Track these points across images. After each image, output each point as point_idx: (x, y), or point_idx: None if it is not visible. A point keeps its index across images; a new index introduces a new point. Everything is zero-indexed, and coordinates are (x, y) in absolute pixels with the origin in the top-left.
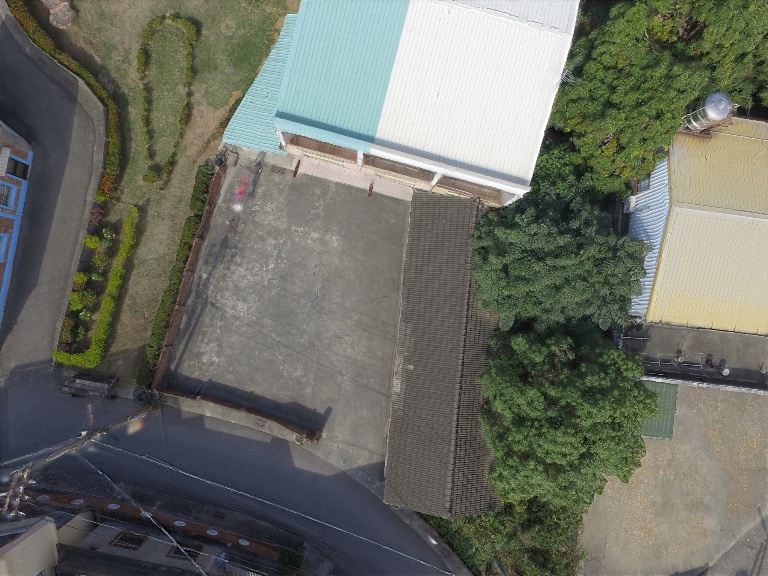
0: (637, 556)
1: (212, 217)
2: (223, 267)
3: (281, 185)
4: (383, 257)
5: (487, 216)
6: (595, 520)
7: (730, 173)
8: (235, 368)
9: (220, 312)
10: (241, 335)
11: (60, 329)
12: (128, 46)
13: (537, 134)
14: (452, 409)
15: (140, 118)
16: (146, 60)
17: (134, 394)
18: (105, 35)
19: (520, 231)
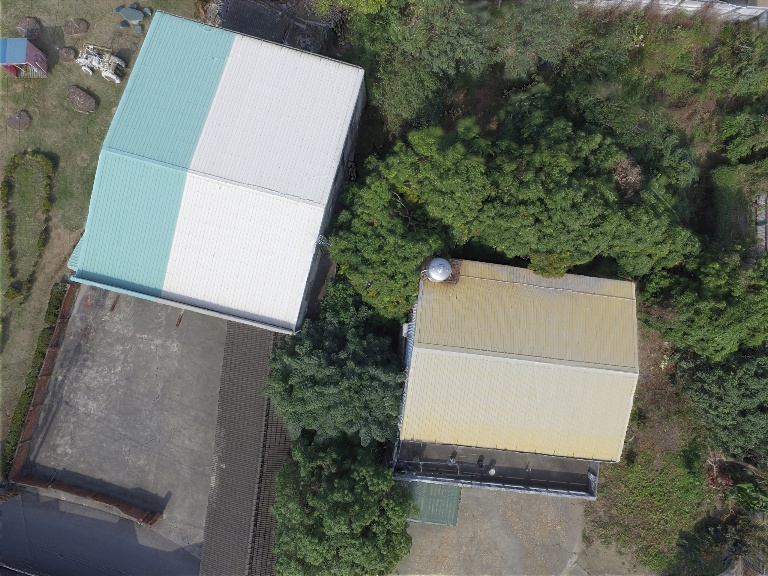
0: None
1: (67, 326)
2: (76, 370)
3: (128, 298)
4: (218, 360)
5: (284, 339)
6: None
7: (485, 306)
8: (86, 458)
9: (73, 410)
10: (91, 430)
11: None
12: None
13: (299, 286)
14: (252, 505)
15: None
16: (9, 191)
17: None
18: None
19: (298, 360)
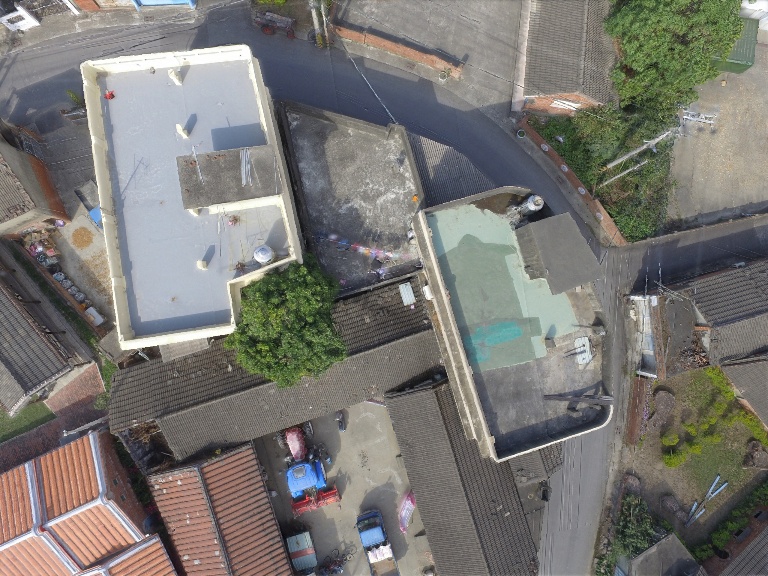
0: (718, 187)
1: None
2: None
3: None
4: None
5: None
6: (684, 155)
7: None
8: (390, 18)
9: None
10: None
11: None
12: None
13: None
14: (583, 11)
15: None
16: None
17: (308, 35)
18: None
19: None
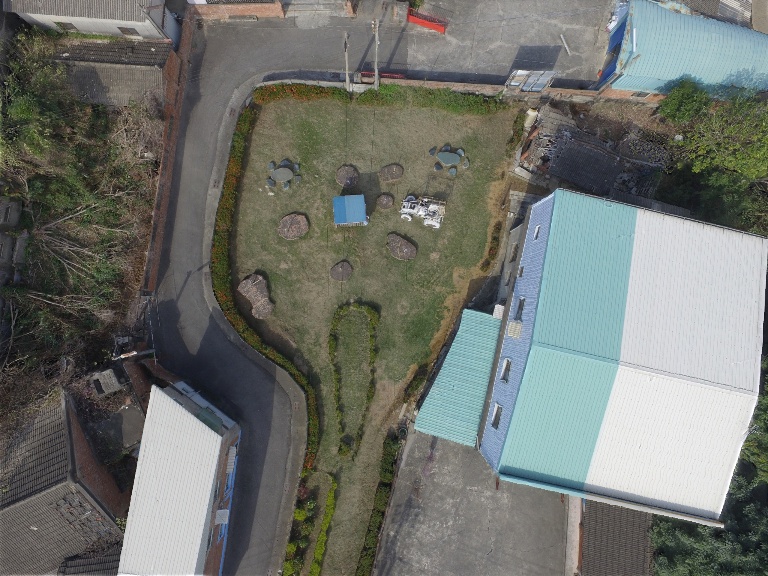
0: None
1: (396, 480)
2: (408, 525)
3: (456, 448)
4: (548, 510)
5: None
6: None
7: None
8: None
9: (407, 566)
10: None
11: None
12: (318, 330)
13: (727, 475)
14: None
15: (331, 394)
16: (336, 344)
17: None
18: (298, 321)
19: (704, 542)
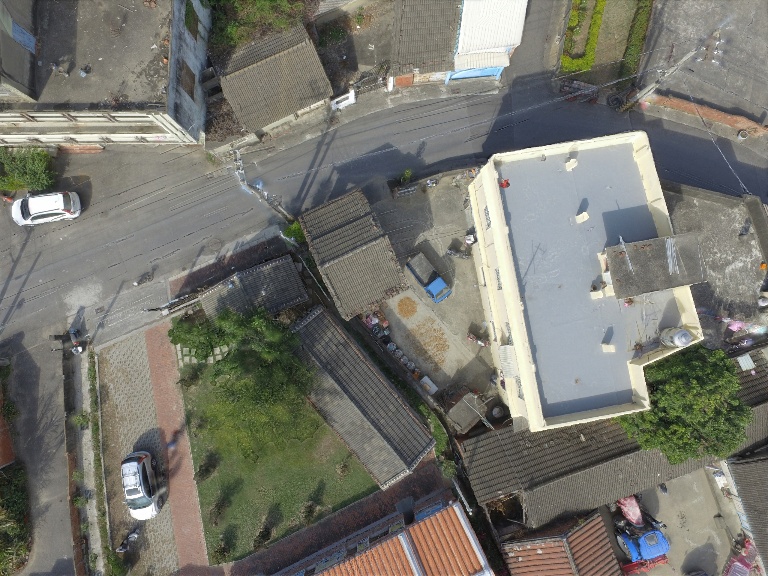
0: None
1: None
2: None
3: None
4: None
5: None
6: None
7: None
8: (688, 79)
9: (674, 34)
10: None
11: (564, 39)
12: None
13: None
14: None
15: None
16: None
17: (609, 100)
18: None
19: None
